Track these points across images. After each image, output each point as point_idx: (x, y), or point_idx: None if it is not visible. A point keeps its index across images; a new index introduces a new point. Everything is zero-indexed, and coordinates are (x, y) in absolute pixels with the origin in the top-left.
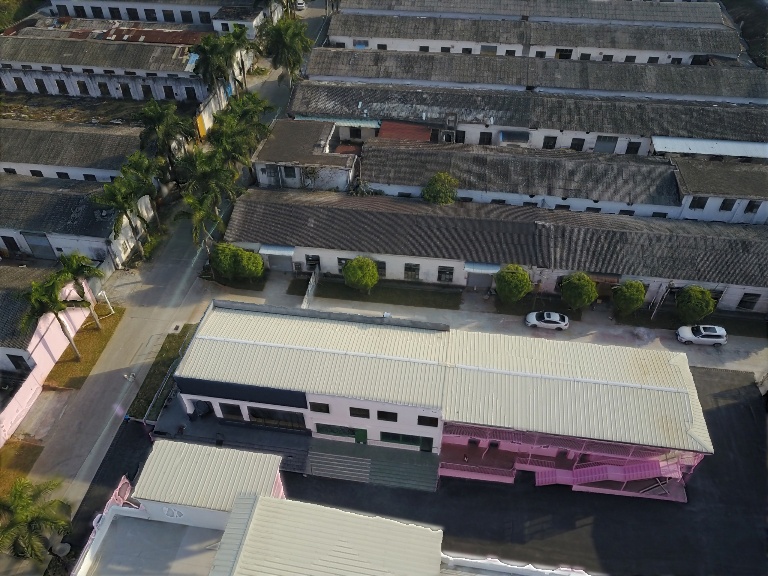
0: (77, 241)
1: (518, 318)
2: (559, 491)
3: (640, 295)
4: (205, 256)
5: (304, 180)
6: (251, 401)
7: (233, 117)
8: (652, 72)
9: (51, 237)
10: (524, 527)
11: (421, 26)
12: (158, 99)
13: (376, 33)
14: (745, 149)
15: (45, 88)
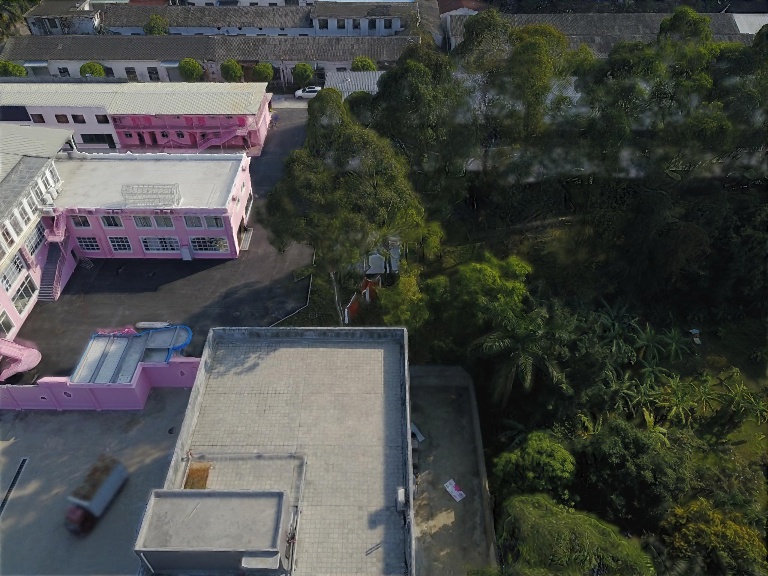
0: None
1: None
2: None
3: (266, 69)
4: None
5: (64, 29)
6: None
7: None
8: None
9: None
10: None
11: None
12: None
13: None
14: (377, 0)
15: None
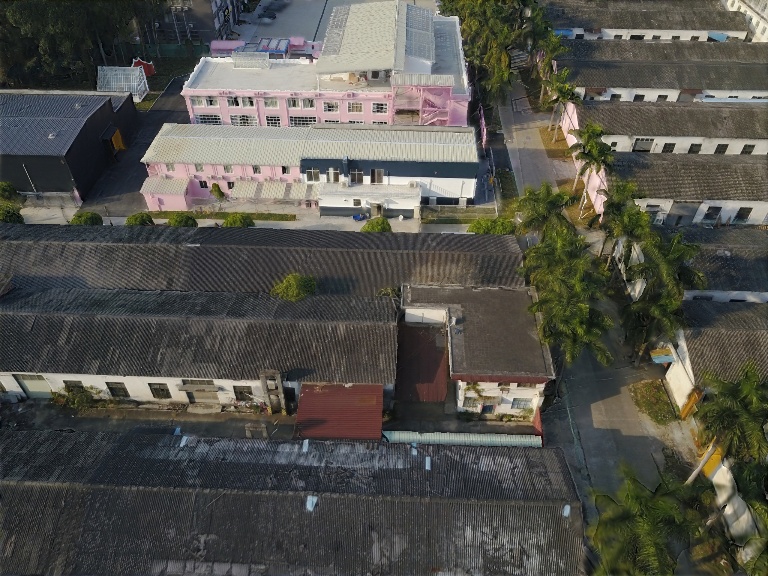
0: None
1: None
2: None
3: None
4: None
5: None
6: None
7: None
8: None
9: None
10: None
11: None
12: None
13: None
14: None
15: None
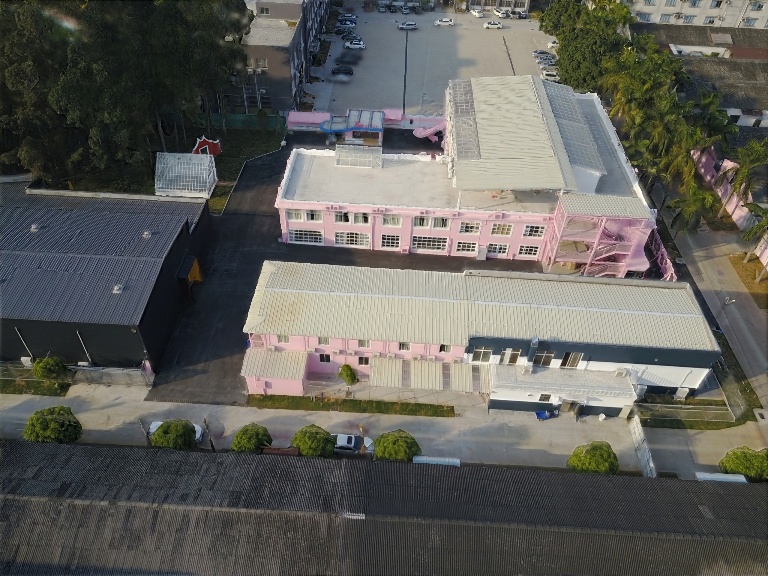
0: None
1: None
2: None
3: None
4: None
5: None
6: None
7: None
8: None
9: None
10: None
11: None
12: None
13: None
14: None
15: None
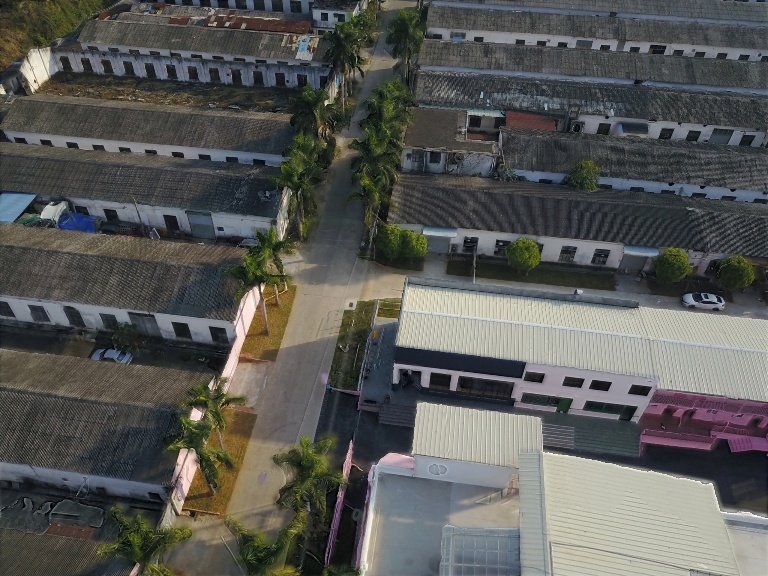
0: (241, 221)
1: (673, 299)
2: (755, 457)
3: None
4: (359, 237)
5: (448, 166)
6: (465, 371)
7: (389, 103)
8: (755, 69)
9: (216, 216)
10: (731, 489)
11: (517, 20)
12: (268, 86)
13: (474, 26)
14: None
15: (154, 73)
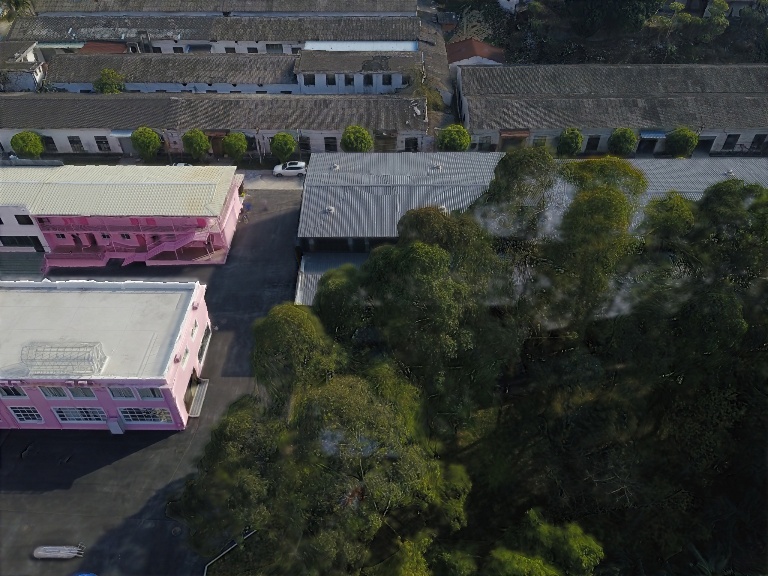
0: None
1: None
2: (136, 267)
3: (238, 141)
4: None
5: None
6: None
7: None
8: None
9: None
10: None
11: None
12: None
13: None
14: (374, 46)
15: None
